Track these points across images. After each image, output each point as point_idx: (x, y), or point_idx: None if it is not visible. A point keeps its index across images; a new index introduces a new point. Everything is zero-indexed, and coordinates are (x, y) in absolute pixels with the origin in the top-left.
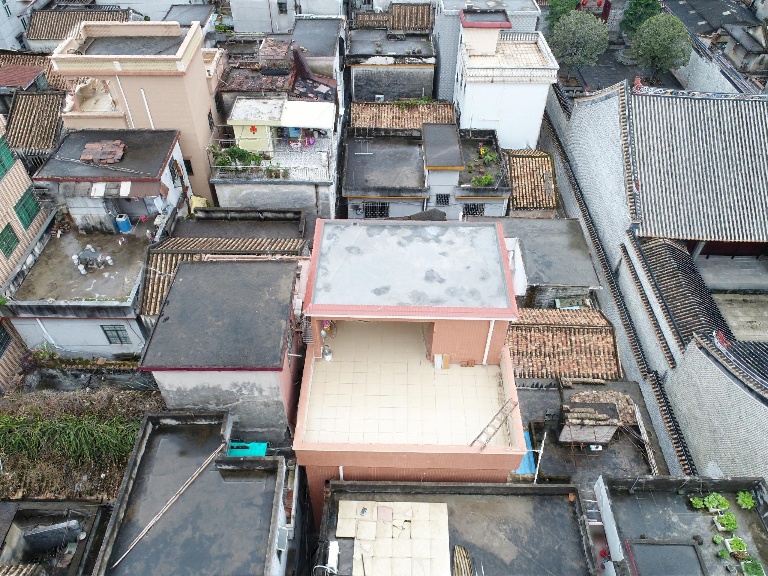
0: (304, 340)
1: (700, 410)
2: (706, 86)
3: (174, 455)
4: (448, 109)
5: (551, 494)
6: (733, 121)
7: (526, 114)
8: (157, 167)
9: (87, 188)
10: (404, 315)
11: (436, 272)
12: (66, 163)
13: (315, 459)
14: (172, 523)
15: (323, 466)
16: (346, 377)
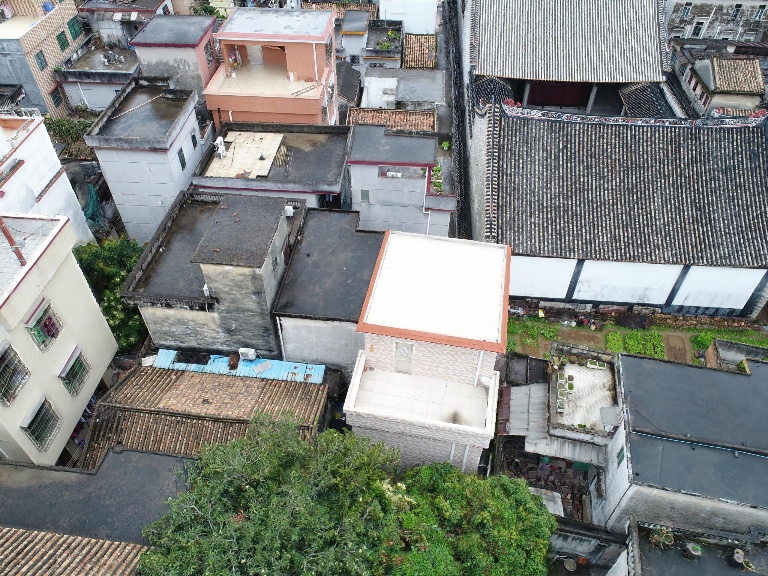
0: (219, 61)
1: (474, 151)
2: None
3: (144, 93)
4: (372, 7)
5: (339, 133)
6: (551, 3)
7: (425, 9)
8: (154, 5)
9: (111, 15)
10: (267, 38)
11: (291, 26)
12: (99, 3)
13: (215, 104)
14: (140, 110)
15: (221, 112)
16: (241, 83)
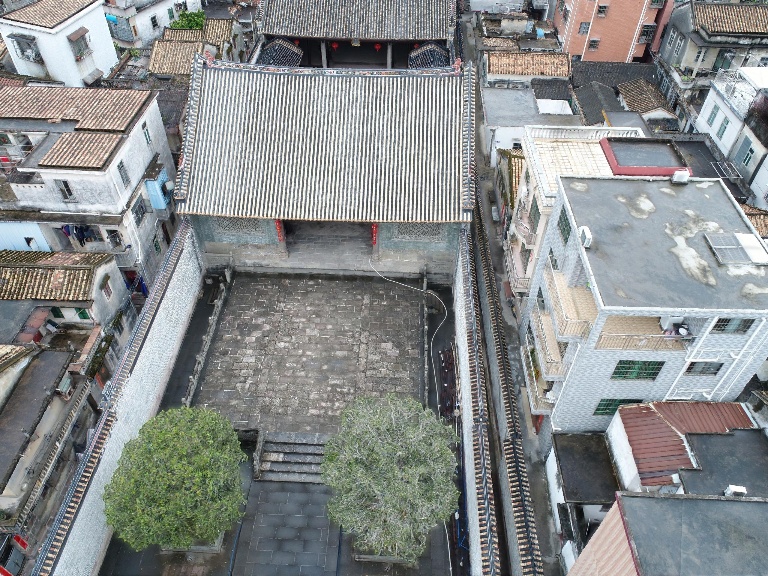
0: None
1: None
2: (135, 421)
3: None
4: None
5: None
6: None
7: None
8: None
9: None
10: None
11: None
12: None
13: None
14: None
15: None
16: None
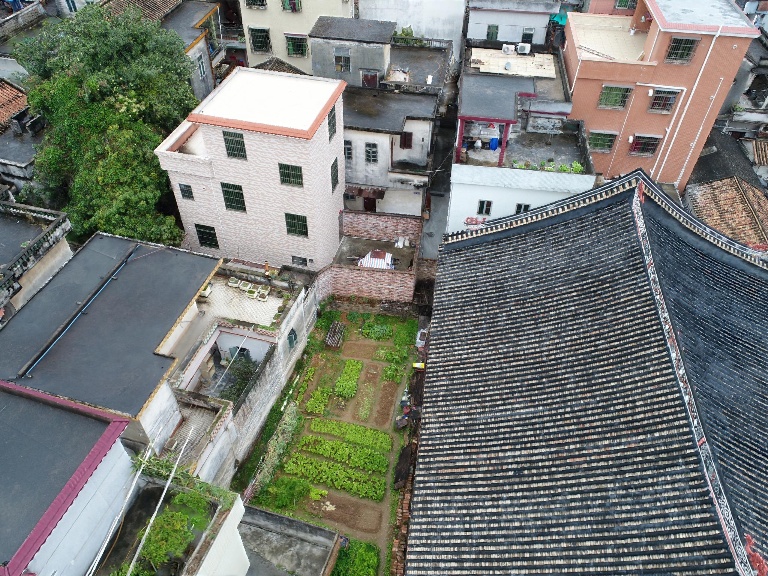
0: None
1: None
2: None
3: None
4: None
5: None
6: None
7: None
8: None
9: None
10: None
11: (692, 12)
12: None
13: None
14: None
15: None
16: (621, 38)
